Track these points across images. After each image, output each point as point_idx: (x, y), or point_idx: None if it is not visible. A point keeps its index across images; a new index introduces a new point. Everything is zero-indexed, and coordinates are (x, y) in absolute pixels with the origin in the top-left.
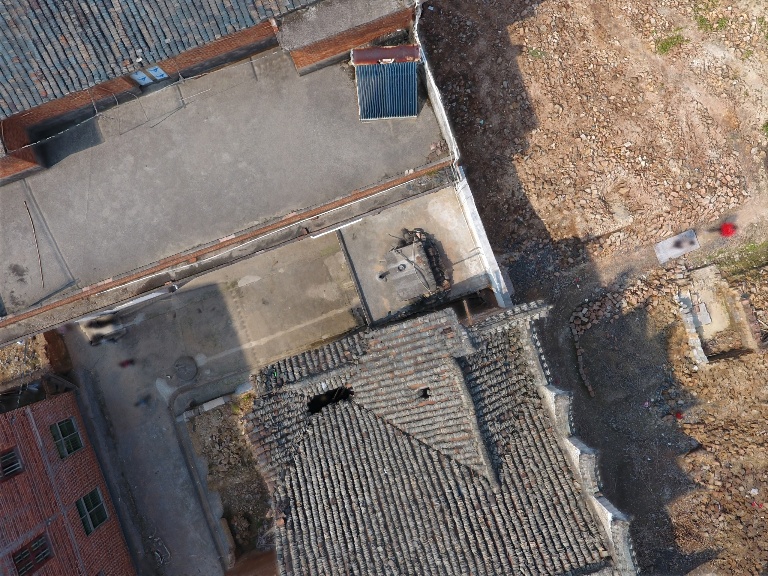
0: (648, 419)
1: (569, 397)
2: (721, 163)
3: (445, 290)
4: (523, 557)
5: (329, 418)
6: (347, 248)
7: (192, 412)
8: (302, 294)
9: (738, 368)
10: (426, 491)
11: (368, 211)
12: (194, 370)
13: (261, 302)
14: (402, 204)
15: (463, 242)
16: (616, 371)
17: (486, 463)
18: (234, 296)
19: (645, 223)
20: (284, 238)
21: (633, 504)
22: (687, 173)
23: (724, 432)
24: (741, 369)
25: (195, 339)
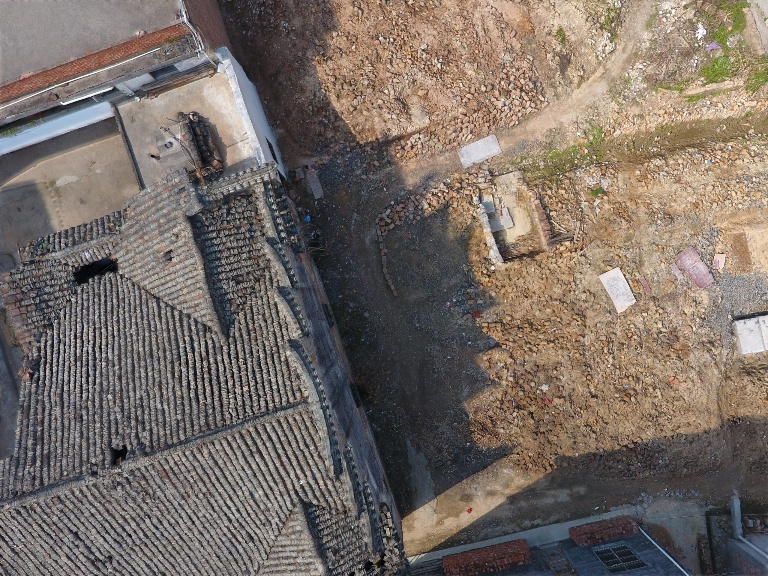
0: (450, 319)
1: (268, 239)
2: (514, 66)
3: (216, 170)
4: (234, 399)
5: (93, 287)
6: (126, 130)
7: (2, 304)
8: (118, 194)
9: (531, 267)
10: (162, 346)
11: (115, 78)
12: (12, 267)
13: (79, 202)
14: (179, 88)
15: (237, 125)
16: (417, 270)
17: (212, 315)
18: (53, 196)
19: (444, 125)
20: (36, 104)
21: (432, 400)
22: (482, 76)
23: (519, 330)
24: (534, 268)
25: (14, 237)
